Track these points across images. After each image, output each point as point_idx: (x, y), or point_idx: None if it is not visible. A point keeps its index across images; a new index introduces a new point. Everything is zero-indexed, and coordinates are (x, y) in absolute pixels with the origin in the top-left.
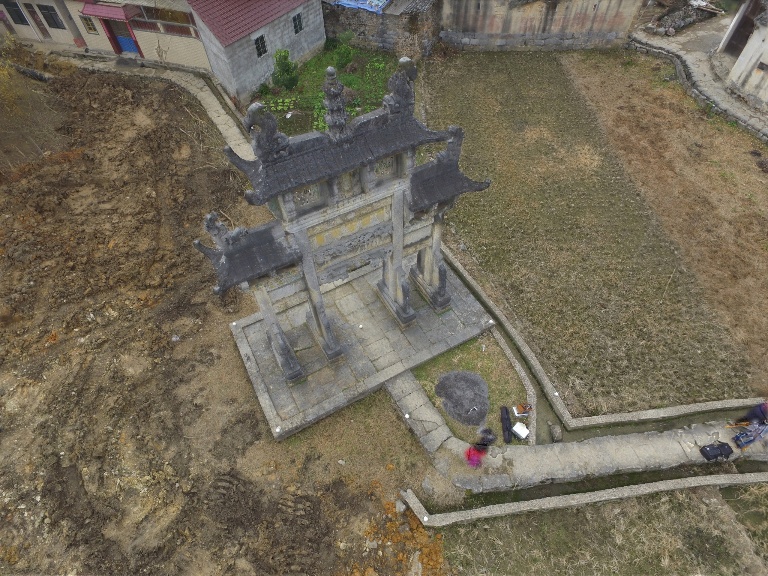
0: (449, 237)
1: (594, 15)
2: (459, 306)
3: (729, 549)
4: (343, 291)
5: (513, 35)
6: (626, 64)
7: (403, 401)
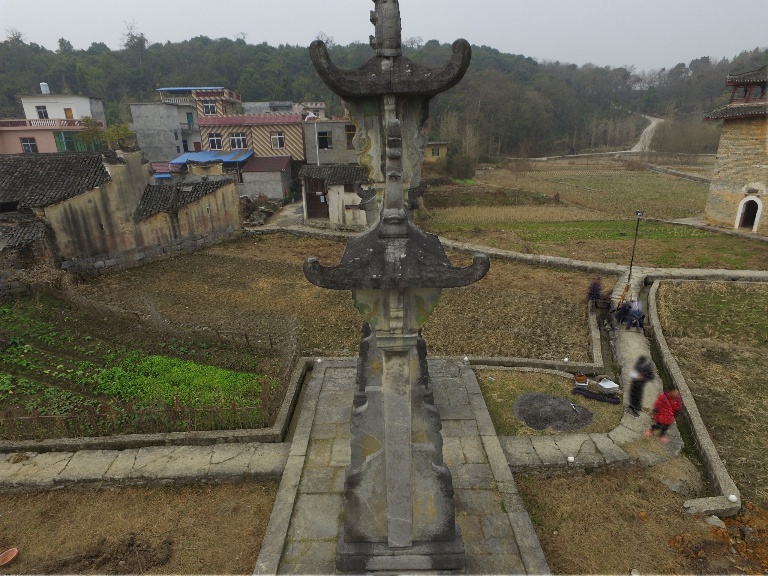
0: (326, 352)
1: (210, 216)
2: (429, 371)
3: (717, 350)
4: (319, 452)
5: (149, 247)
6: (259, 241)
7: (544, 457)
